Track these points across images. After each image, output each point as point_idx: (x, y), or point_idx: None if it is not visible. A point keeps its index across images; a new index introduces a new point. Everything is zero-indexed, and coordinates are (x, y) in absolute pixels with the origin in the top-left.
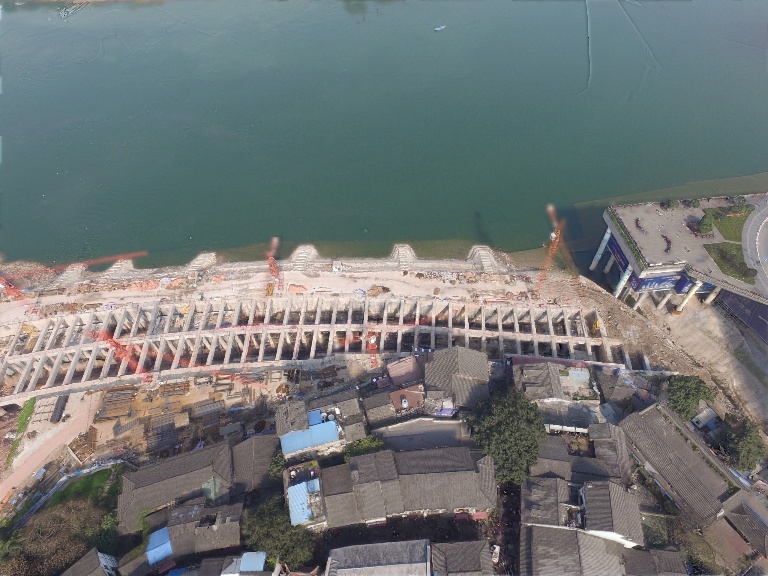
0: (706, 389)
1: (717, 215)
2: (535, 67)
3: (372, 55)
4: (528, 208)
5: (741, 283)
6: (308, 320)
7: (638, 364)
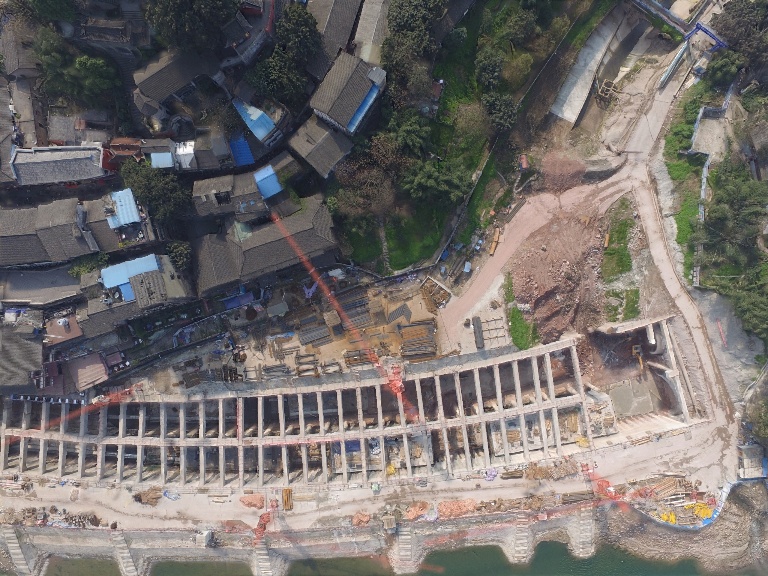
0: None
1: None
2: None
3: None
4: None
5: None
6: (246, 459)
7: None
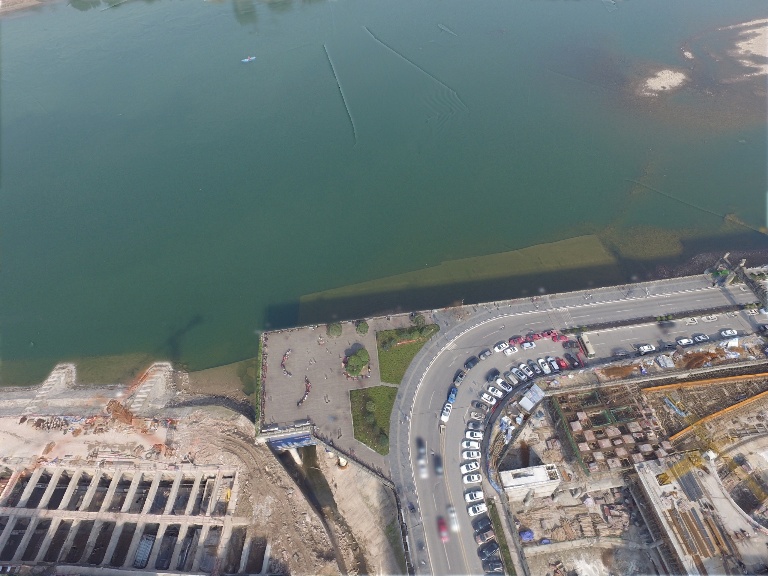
0: None
1: (388, 342)
2: (338, 107)
3: (159, 94)
4: (244, 304)
5: (370, 453)
6: None
7: (263, 553)
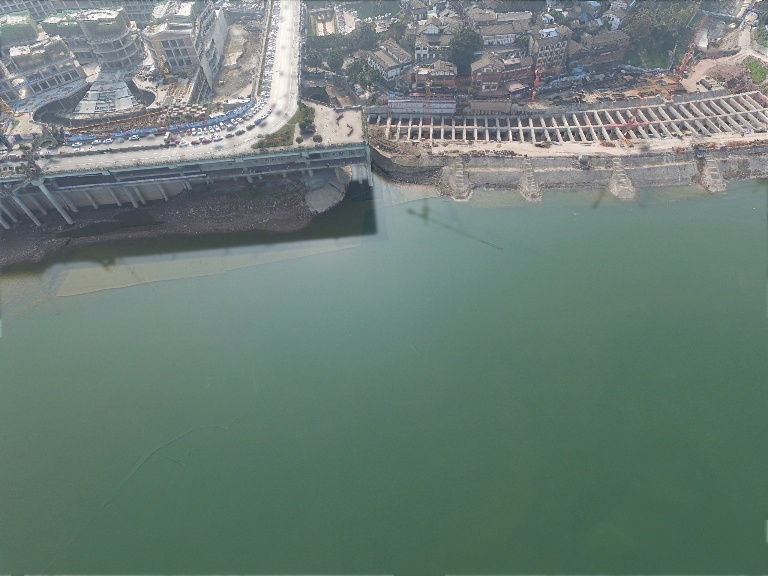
0: (362, 72)
1: (286, 139)
2: None
3: None
4: (410, 239)
5: (308, 104)
6: None
7: None
